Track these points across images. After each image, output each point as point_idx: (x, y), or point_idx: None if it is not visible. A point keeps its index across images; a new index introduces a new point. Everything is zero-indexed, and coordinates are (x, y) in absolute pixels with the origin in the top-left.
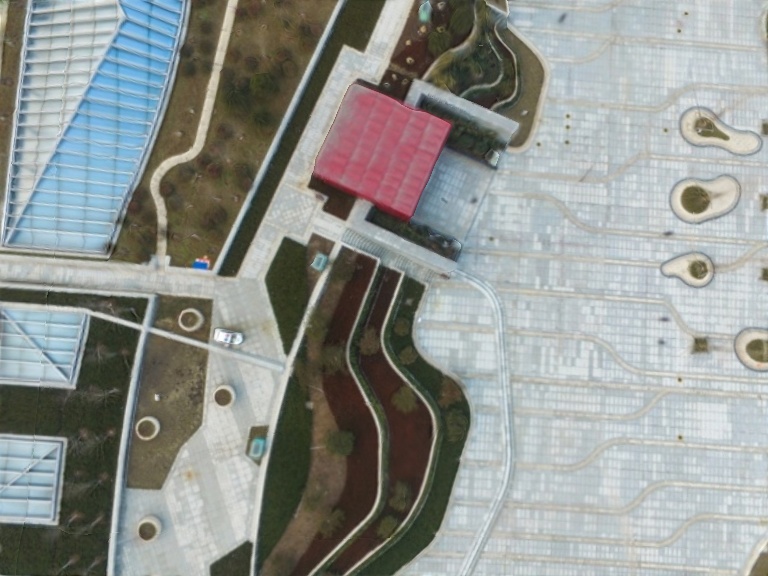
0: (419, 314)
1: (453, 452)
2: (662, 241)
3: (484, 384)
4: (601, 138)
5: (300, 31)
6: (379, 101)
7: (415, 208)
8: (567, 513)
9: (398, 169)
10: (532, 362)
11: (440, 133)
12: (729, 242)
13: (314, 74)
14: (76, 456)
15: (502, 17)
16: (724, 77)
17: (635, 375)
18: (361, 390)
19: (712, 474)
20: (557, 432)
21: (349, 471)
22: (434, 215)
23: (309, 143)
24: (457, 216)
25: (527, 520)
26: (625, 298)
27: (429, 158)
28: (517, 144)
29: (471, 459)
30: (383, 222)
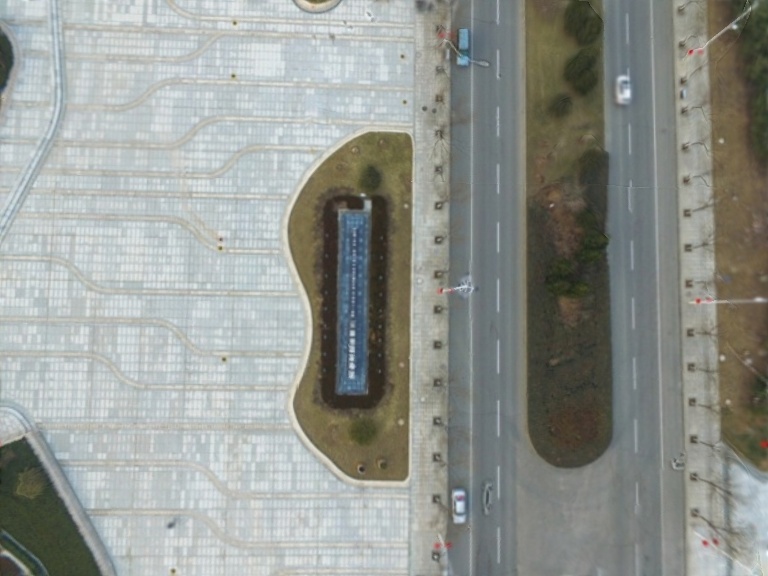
0: None
1: None
2: None
3: (33, 30)
4: None
5: None
6: None
7: None
8: (118, 149)
9: None
10: (85, 10)
11: None
12: None
13: None
14: None
15: None
16: None
17: (190, 20)
18: None
19: (264, 108)
20: (109, 75)
21: None
22: None
23: None
24: None
25: (77, 157)
26: None
27: None
28: None
29: (18, 100)
30: None
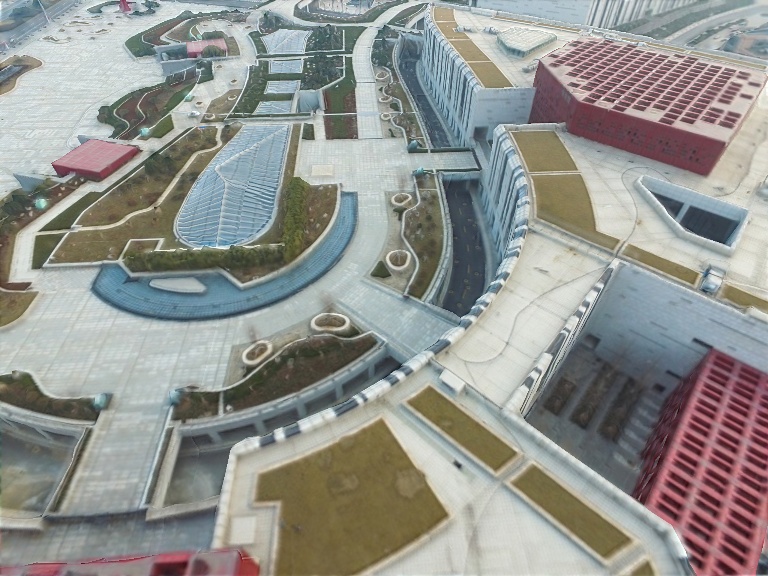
0: None
1: None
2: None
3: None
4: None
5: (124, 189)
6: None
7: None
8: None
9: None
10: None
11: (60, 160)
12: None
13: None
14: (260, 90)
15: None
16: None
17: None
18: (142, 112)
19: None
20: None
21: None
22: None
23: (137, 162)
24: None
25: None
26: None
27: None
28: None
29: None
30: None
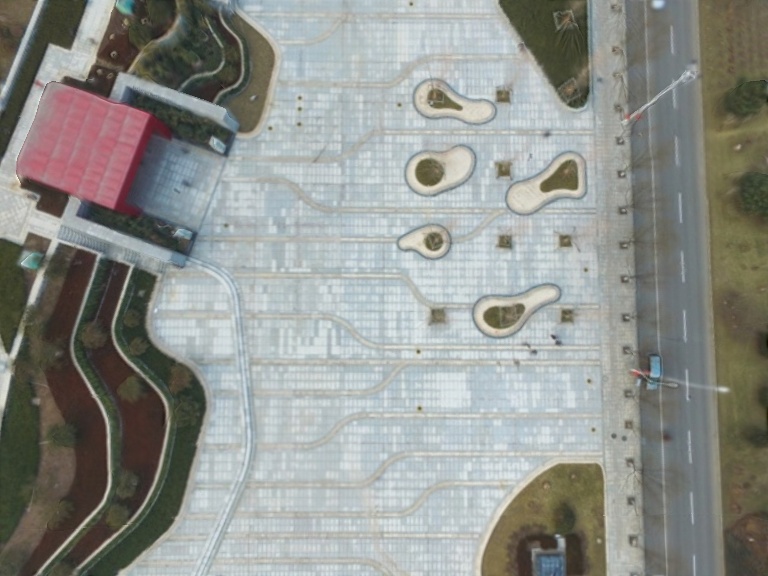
0: (155, 305)
1: (188, 438)
2: (398, 216)
3: (222, 369)
4: (334, 117)
5: None
6: (77, 97)
7: (117, 201)
8: (309, 490)
9: (99, 163)
10: (270, 344)
11: (139, 124)
12: (465, 212)
13: (19, 75)
14: None
15: (222, 4)
16: (457, 47)
17: (374, 350)
18: (87, 383)
19: (452, 442)
20: (297, 411)
21: (78, 463)
22: (167, 206)
23: (20, 144)
24: (190, 205)
25: (269, 499)
26: (362, 275)
27: (129, 150)
28: (247, 130)
29: (210, 443)
30: (96, 217)
